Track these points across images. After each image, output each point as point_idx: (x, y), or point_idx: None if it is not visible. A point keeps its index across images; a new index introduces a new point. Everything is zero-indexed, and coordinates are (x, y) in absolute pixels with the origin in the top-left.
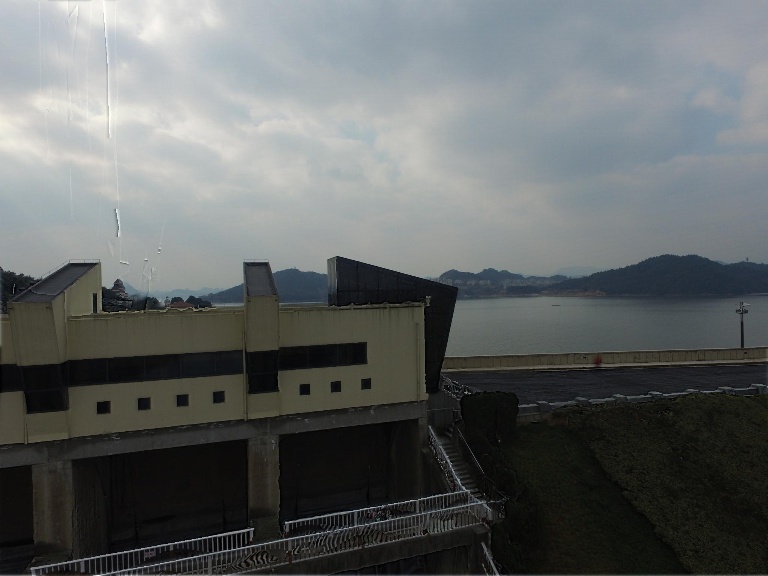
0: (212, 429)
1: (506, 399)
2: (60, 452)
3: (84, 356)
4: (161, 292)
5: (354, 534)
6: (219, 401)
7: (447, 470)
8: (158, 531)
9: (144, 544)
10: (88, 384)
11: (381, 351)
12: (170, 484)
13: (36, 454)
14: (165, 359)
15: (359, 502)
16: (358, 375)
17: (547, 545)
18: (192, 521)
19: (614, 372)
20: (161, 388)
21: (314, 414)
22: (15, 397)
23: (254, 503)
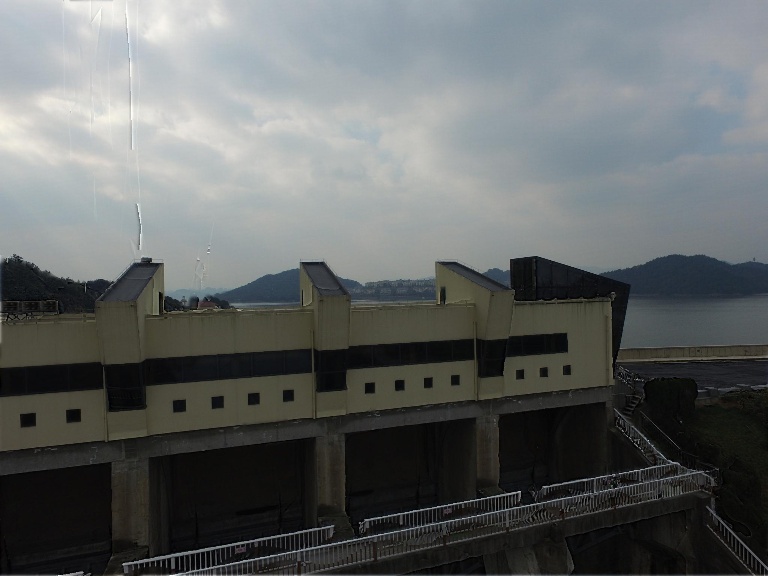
0: (449, 408)
1: (687, 384)
2: (336, 426)
3: (355, 343)
4: (210, 291)
5: (609, 496)
6: (455, 384)
7: (643, 447)
8: (363, 503)
9: (354, 514)
10: (358, 367)
11: (578, 341)
12: (358, 463)
13: (319, 428)
14: (414, 346)
15: (524, 480)
16: (560, 362)
17: (761, 509)
18: (390, 495)
19: (733, 364)
20: (412, 372)
21: (526, 396)
22: (305, 378)
23: (480, 474)
